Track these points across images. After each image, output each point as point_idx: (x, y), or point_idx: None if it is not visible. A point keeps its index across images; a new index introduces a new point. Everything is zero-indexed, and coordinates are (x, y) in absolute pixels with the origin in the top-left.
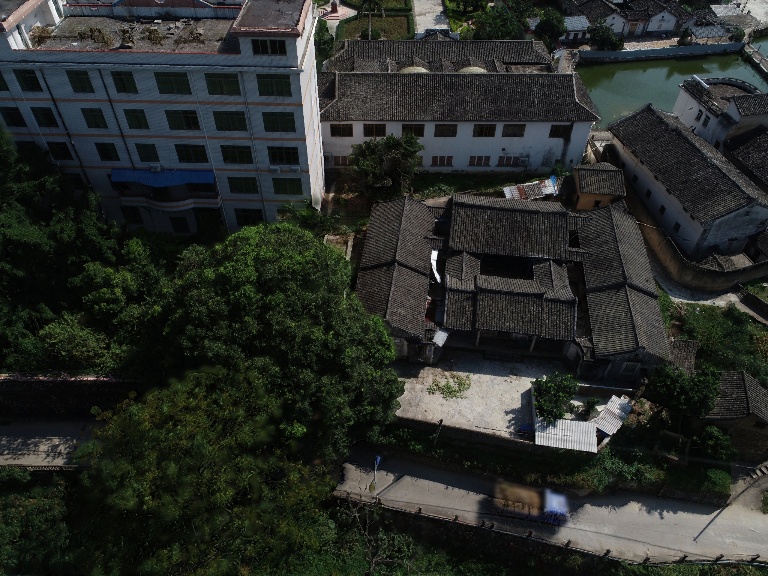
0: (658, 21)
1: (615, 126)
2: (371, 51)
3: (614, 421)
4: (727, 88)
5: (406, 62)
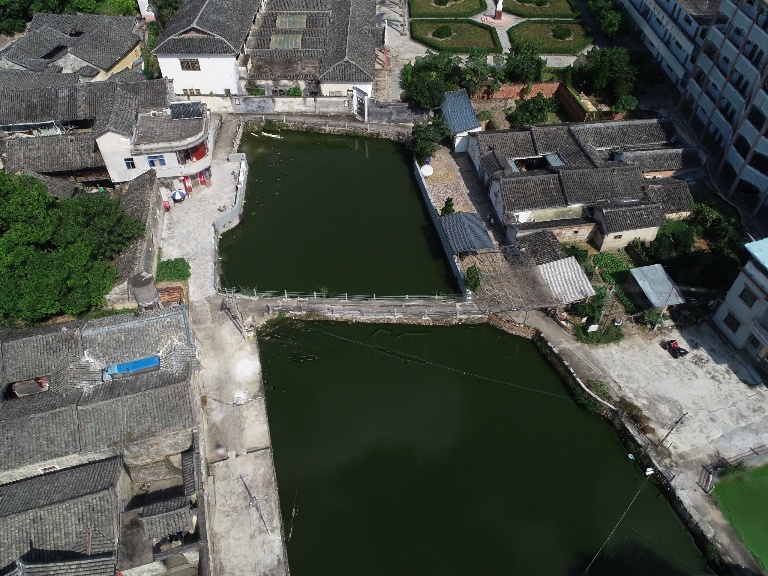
0: (494, 191)
1: None
2: None
3: None
4: (190, 133)
5: None
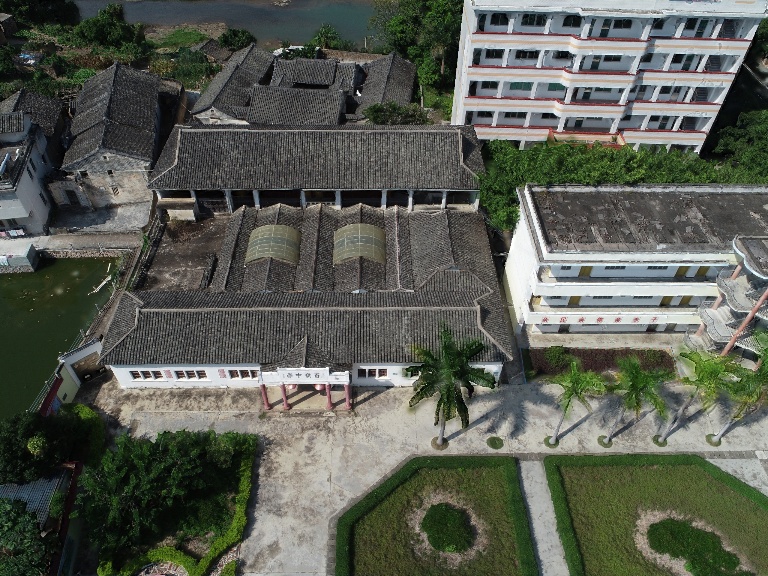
0: None
1: (147, 156)
2: (431, 300)
3: (277, 51)
4: None
5: (371, 282)
